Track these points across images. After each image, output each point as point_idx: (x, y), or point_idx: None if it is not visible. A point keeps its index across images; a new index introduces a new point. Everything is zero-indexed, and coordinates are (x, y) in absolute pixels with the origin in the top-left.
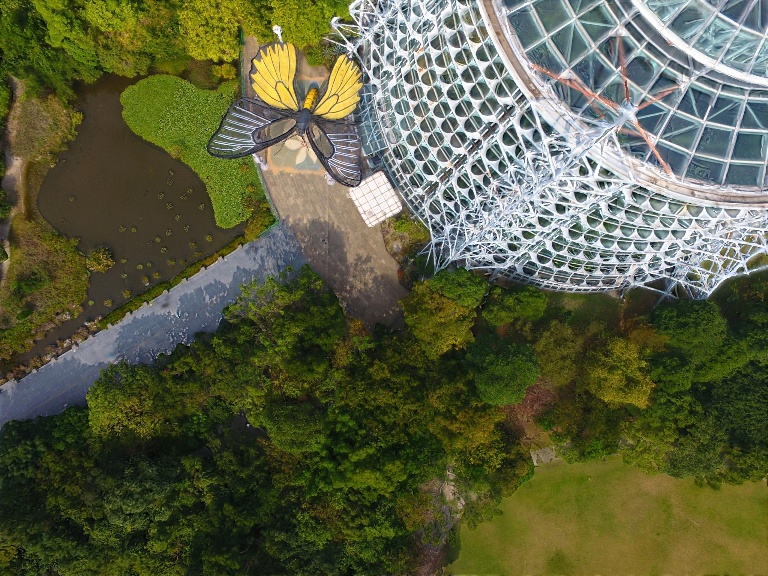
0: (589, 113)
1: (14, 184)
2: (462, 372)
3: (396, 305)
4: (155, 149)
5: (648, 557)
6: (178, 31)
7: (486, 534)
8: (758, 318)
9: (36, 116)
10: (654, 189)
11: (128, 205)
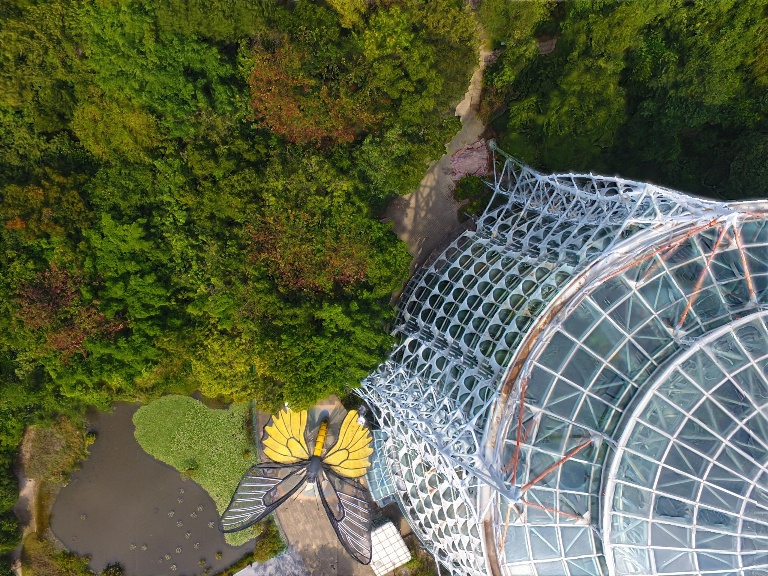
0: None
1: (27, 504)
2: None
3: None
4: (166, 467)
5: None
6: (191, 371)
7: None
8: None
9: (50, 440)
10: None
11: (139, 522)
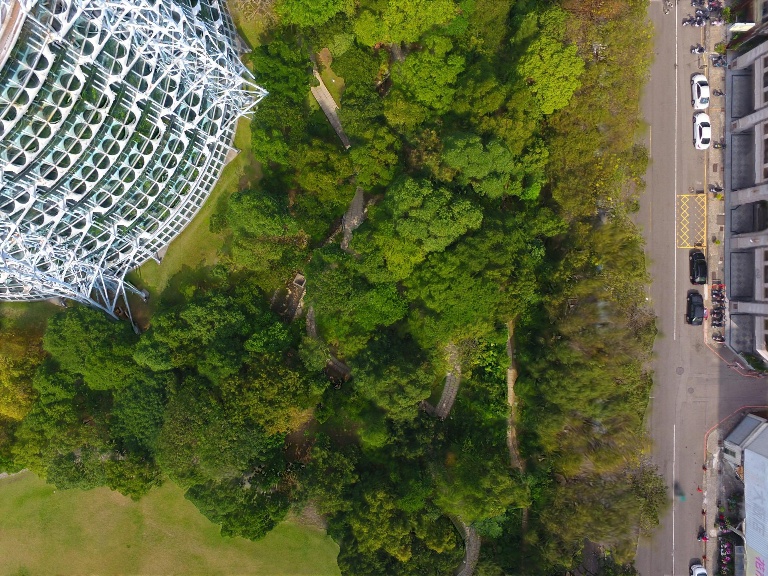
0: None
1: None
2: None
3: None
4: None
5: (118, 571)
6: None
7: None
8: (152, 322)
9: None
10: None
11: None
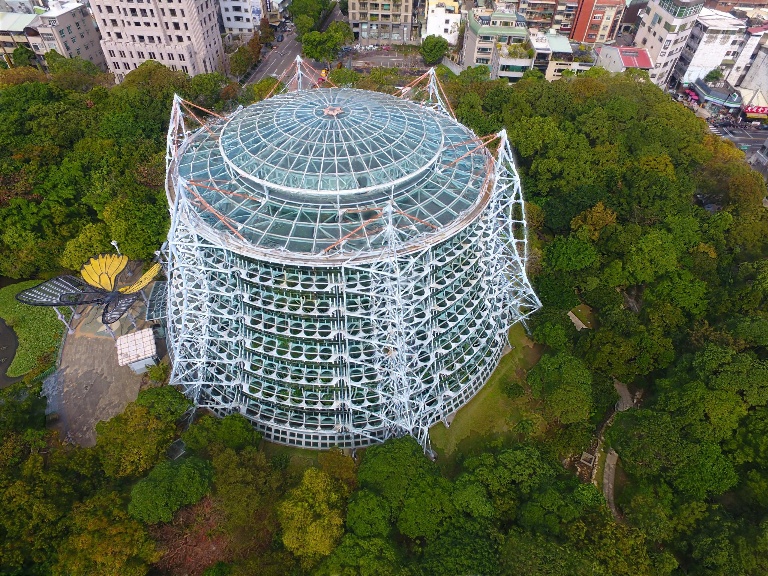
0: (206, 215)
1: None
2: None
3: None
4: None
5: None
6: (62, 253)
7: None
8: (469, 464)
9: None
10: (237, 251)
11: None
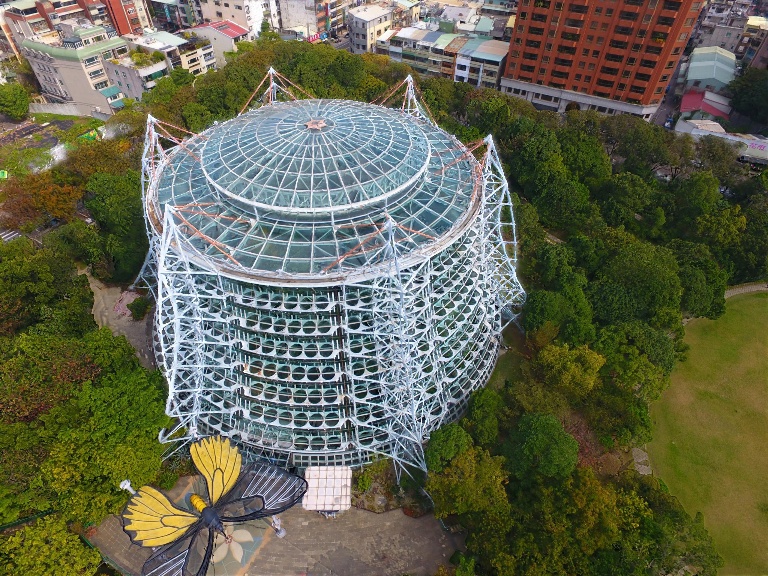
0: (372, 260)
1: None
2: (533, 487)
3: (438, 536)
4: None
5: (762, 429)
6: None
7: None
8: (551, 276)
9: None
10: (439, 251)
11: None
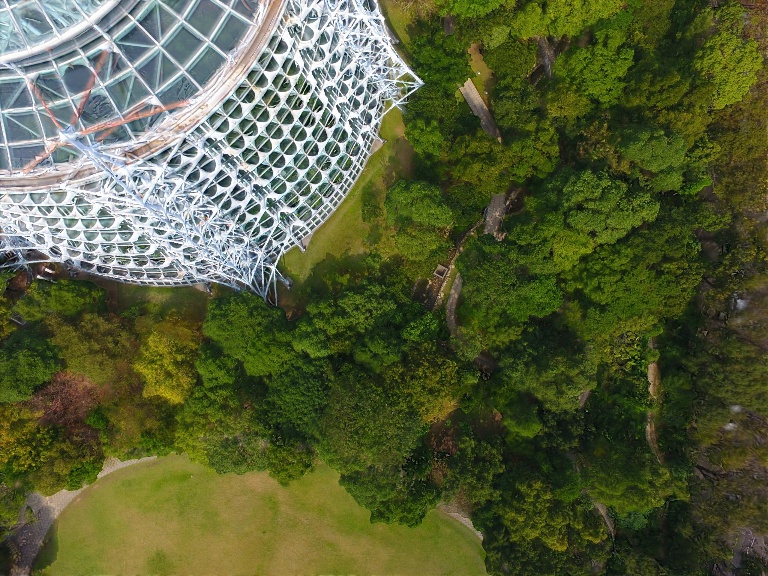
0: None
1: None
2: None
3: None
4: None
5: (253, 556)
6: None
7: (84, 535)
8: (310, 309)
9: None
10: None
11: None
